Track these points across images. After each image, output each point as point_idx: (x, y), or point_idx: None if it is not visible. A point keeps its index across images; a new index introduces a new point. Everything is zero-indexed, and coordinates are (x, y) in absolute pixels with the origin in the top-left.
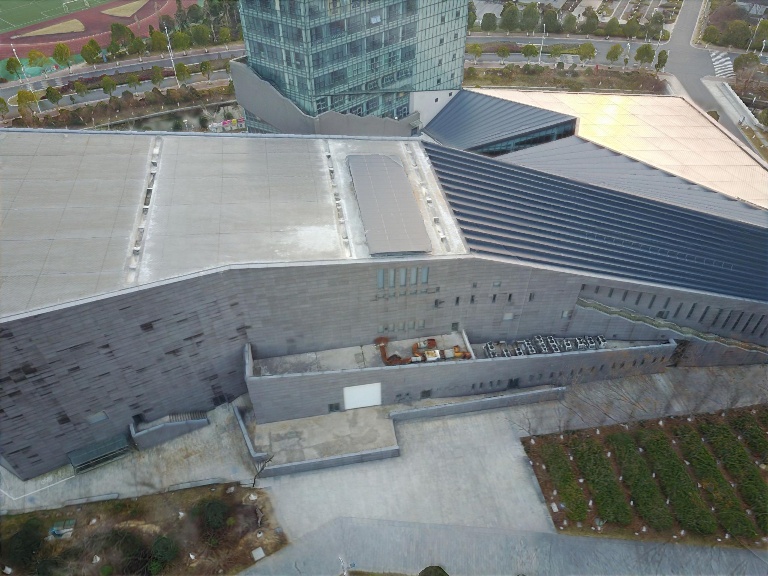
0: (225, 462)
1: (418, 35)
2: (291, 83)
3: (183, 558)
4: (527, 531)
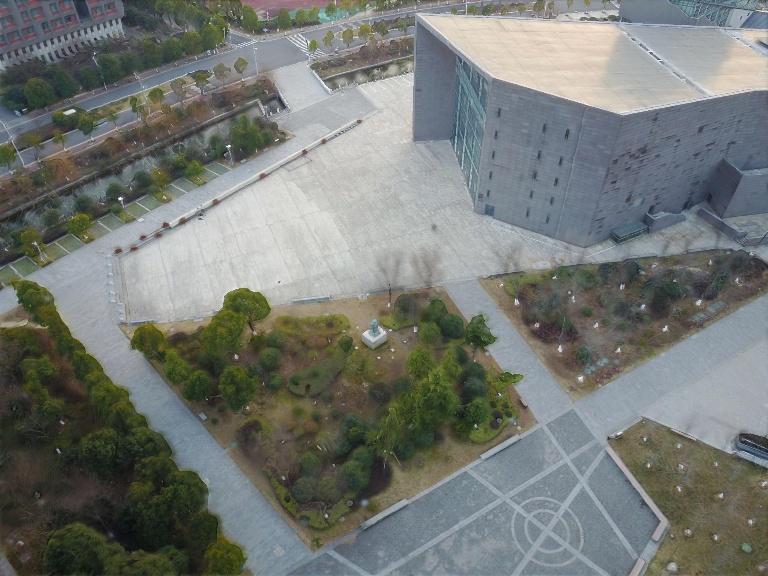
0: (713, 239)
1: None
2: None
3: (730, 283)
4: None
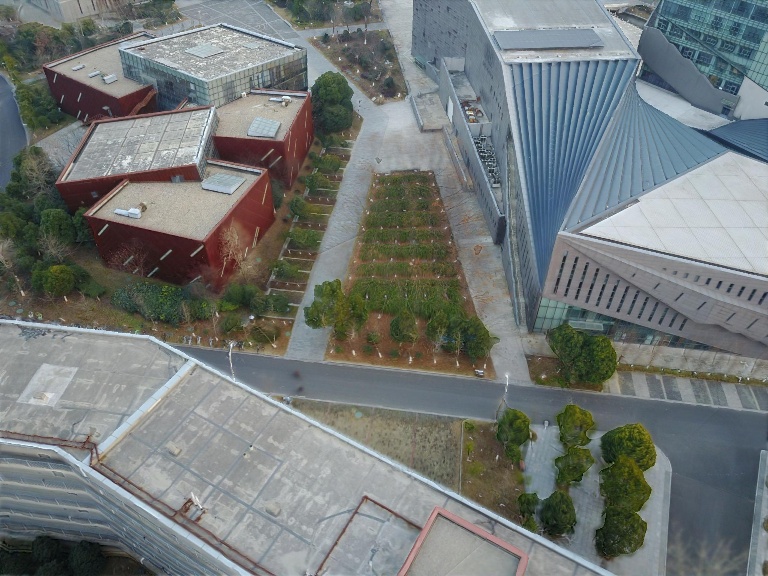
0: None
1: None
2: None
3: None
4: (376, 164)
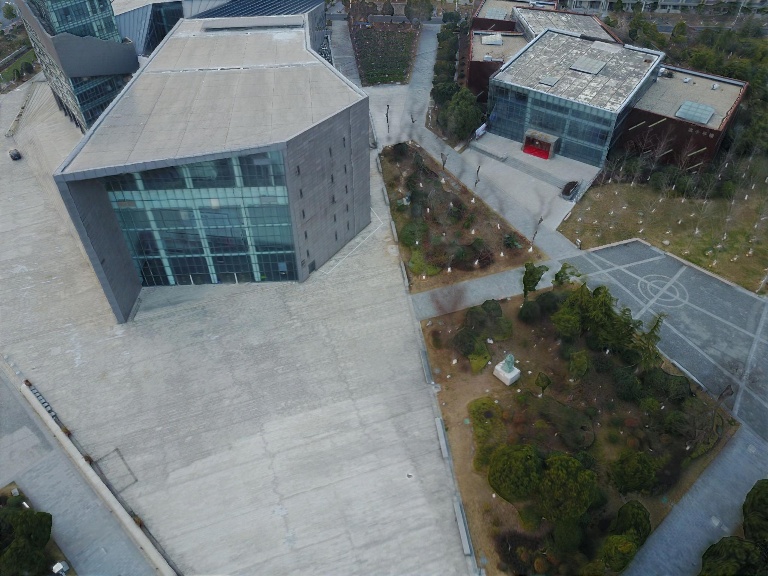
0: None
1: None
2: (99, 29)
3: None
4: None
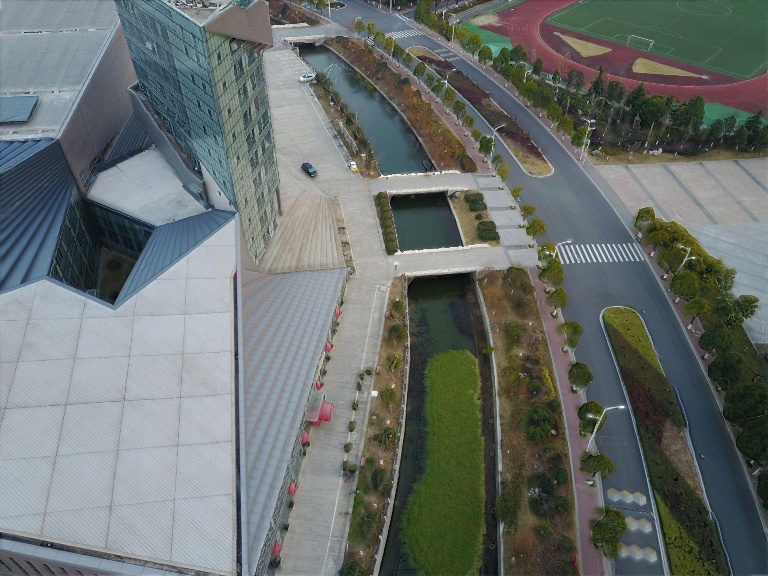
0: None
1: (184, 98)
2: None
3: None
4: None
